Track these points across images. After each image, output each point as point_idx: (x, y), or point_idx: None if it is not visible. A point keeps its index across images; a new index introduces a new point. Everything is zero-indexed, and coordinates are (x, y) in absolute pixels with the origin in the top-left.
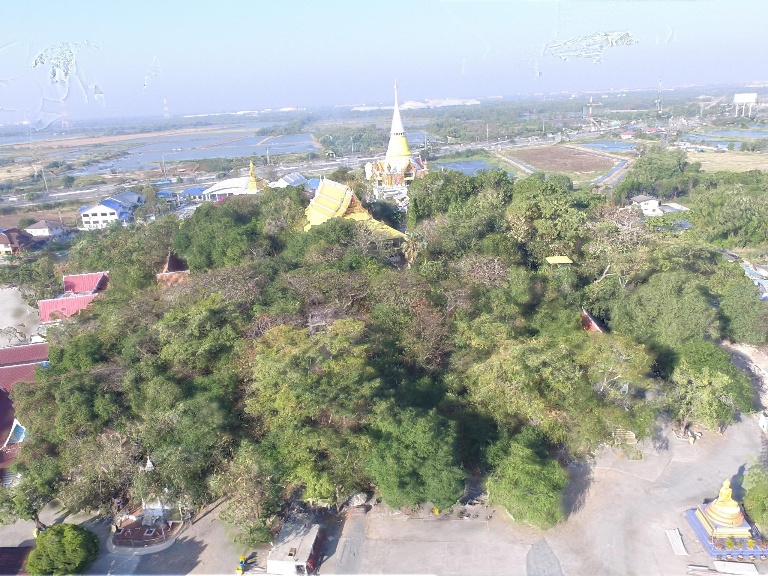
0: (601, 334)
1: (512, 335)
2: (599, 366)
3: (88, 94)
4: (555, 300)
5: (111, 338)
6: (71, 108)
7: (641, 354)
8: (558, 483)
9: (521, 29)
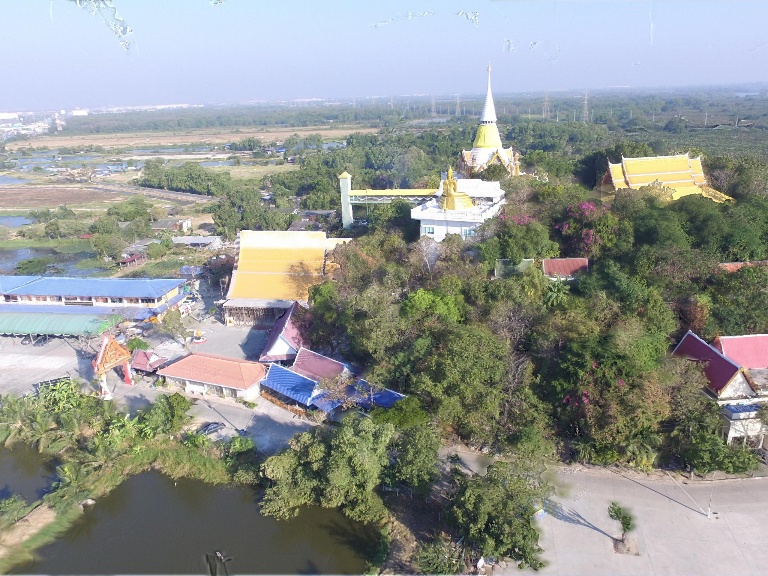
0: None
1: None
2: None
3: None
4: None
5: None
6: None
7: None
8: None
9: None
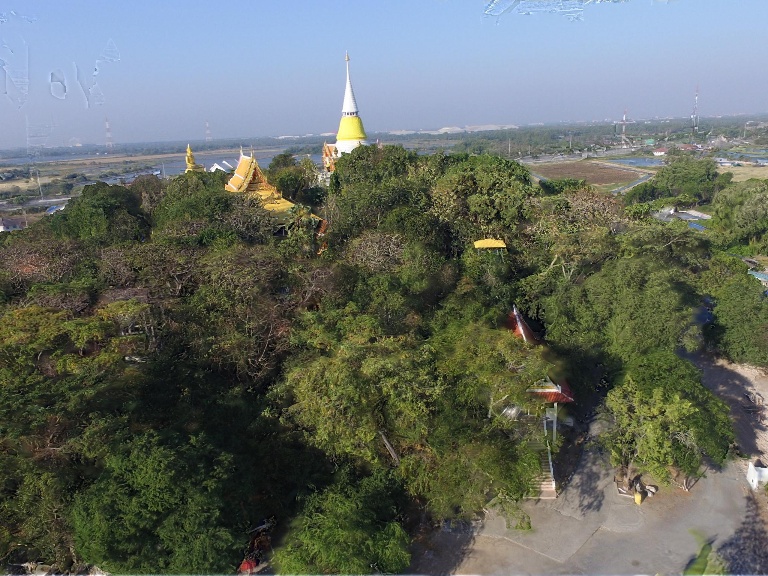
0: (484, 330)
1: (378, 333)
2: (479, 378)
3: (89, 99)
4: (469, 293)
5: None
6: (71, 113)
7: (534, 360)
8: (388, 562)
9: None
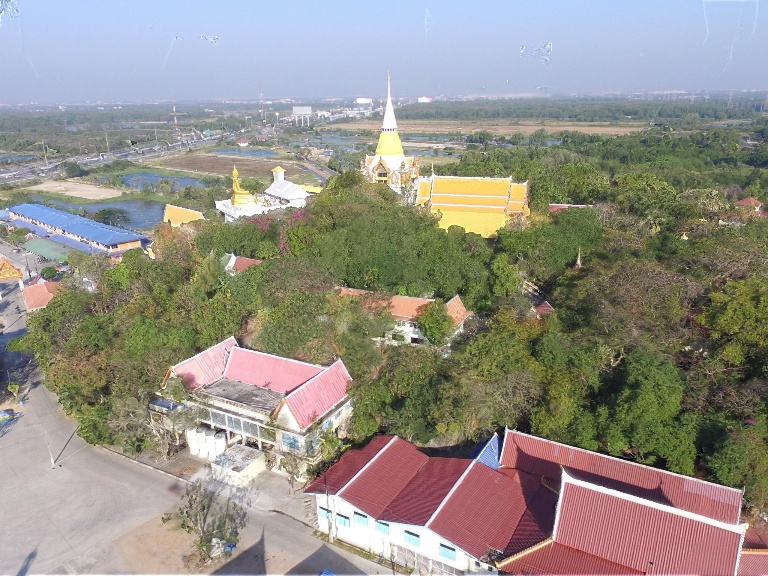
0: None
1: None
2: None
3: None
4: None
5: (583, 380)
6: None
7: None
8: None
9: None
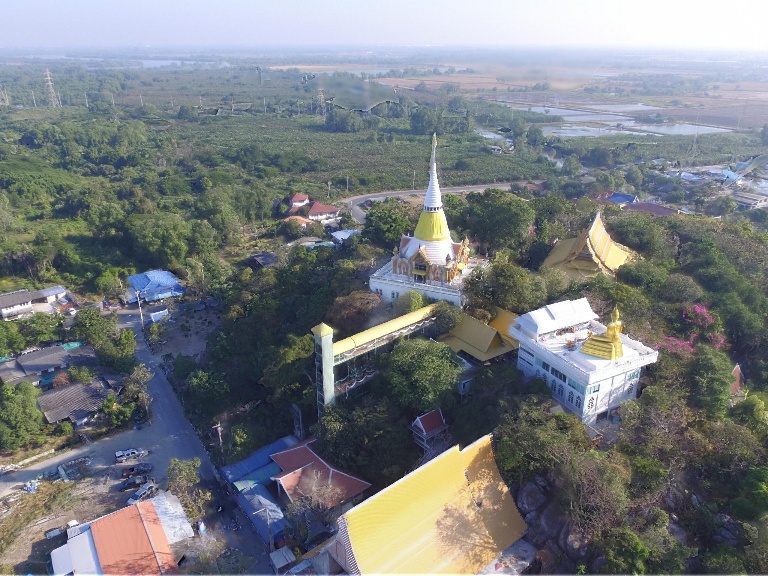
0: None
1: None
2: None
3: None
4: None
5: None
6: None
7: None
8: None
9: (562, 86)
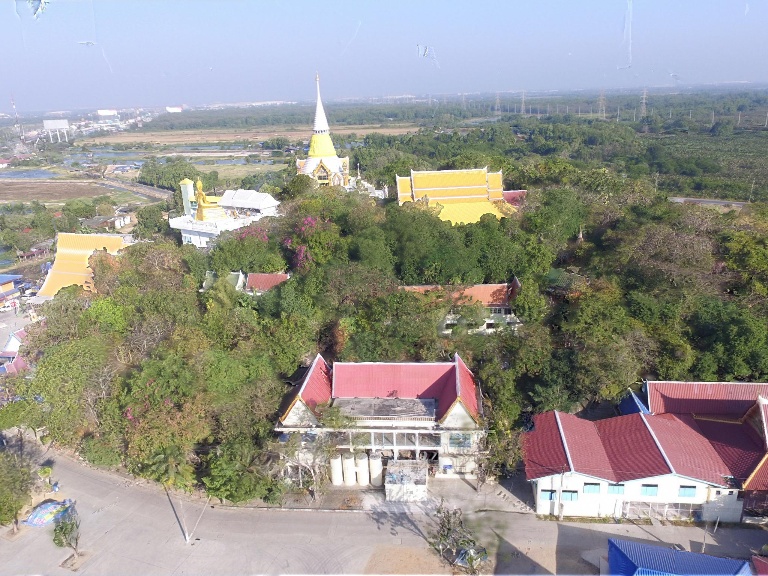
0: None
1: None
2: None
3: None
4: None
5: None
6: None
7: None
8: None
9: None
